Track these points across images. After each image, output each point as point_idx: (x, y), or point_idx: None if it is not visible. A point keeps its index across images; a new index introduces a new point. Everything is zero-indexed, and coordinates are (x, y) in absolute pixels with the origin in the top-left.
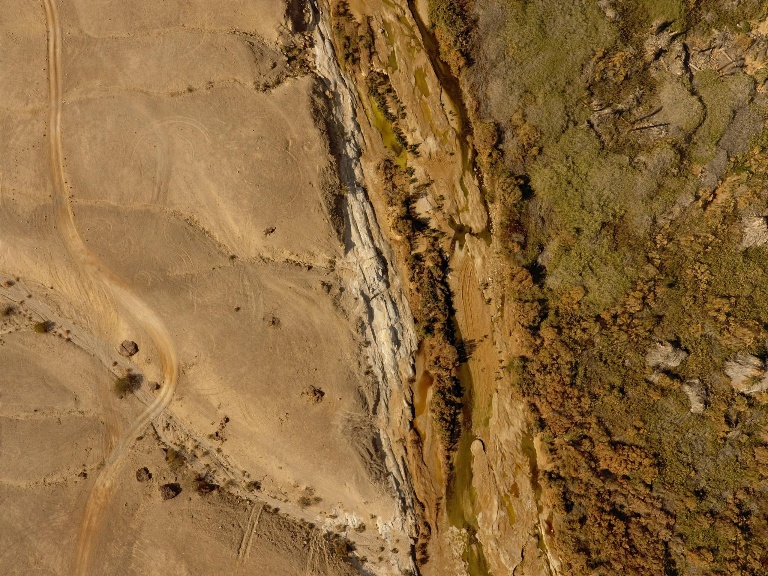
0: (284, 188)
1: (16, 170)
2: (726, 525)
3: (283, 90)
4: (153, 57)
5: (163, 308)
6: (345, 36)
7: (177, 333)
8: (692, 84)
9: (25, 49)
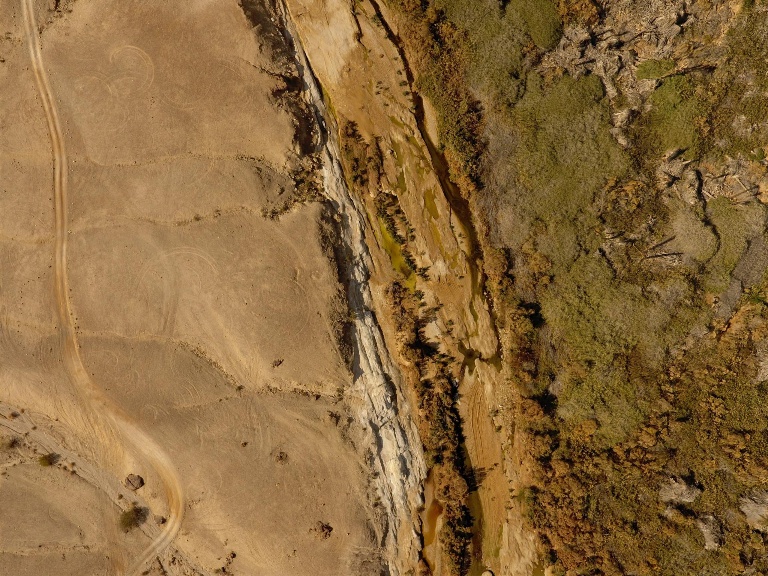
0: (292, 319)
1: (21, 302)
2: None
3: (291, 217)
4: (160, 186)
5: (169, 443)
6: (353, 158)
7: (183, 468)
8: (705, 212)
9: (31, 178)
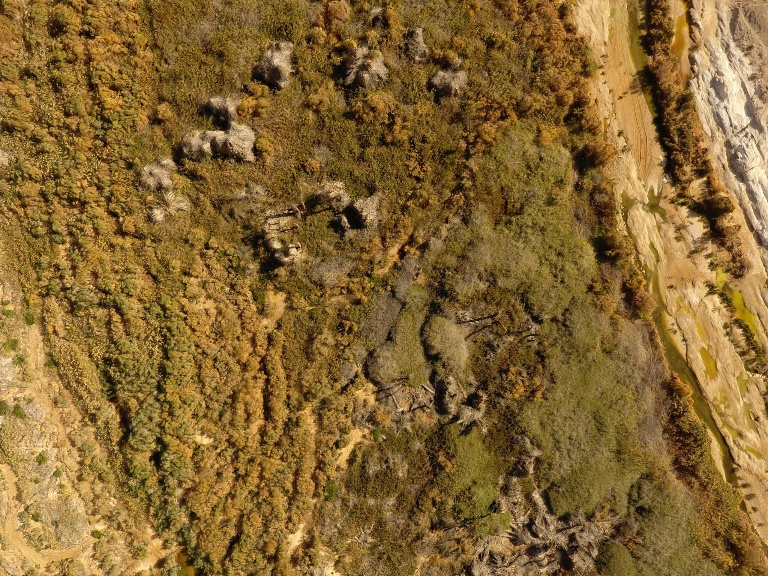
0: None
1: None
2: None
3: None
4: None
5: None
6: None
7: None
8: (432, 369)
9: None
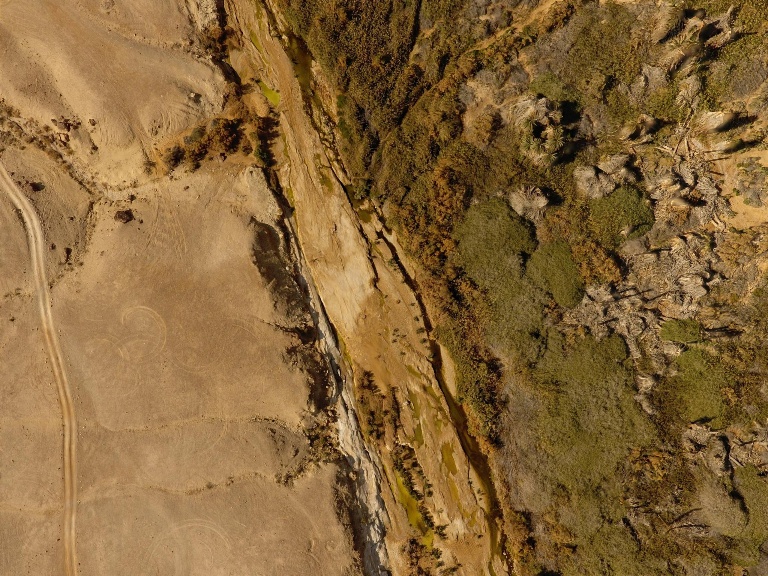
0: None
1: None
2: None
3: (306, 483)
4: (172, 454)
5: None
6: (369, 411)
7: None
8: (733, 482)
9: (40, 447)
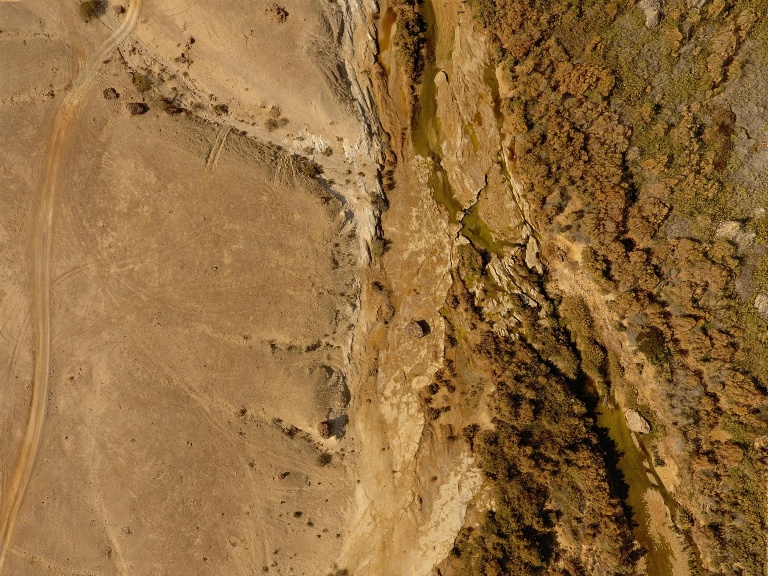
0: None
1: None
2: (680, 129)
3: None
4: None
5: None
6: None
7: None
8: None
9: None
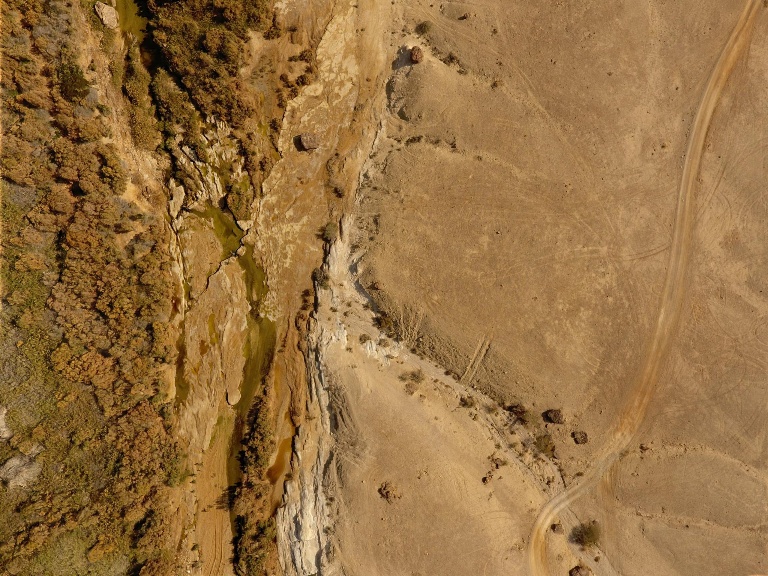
0: None
1: None
2: None
3: None
4: None
5: None
6: None
7: None
8: None
9: None
